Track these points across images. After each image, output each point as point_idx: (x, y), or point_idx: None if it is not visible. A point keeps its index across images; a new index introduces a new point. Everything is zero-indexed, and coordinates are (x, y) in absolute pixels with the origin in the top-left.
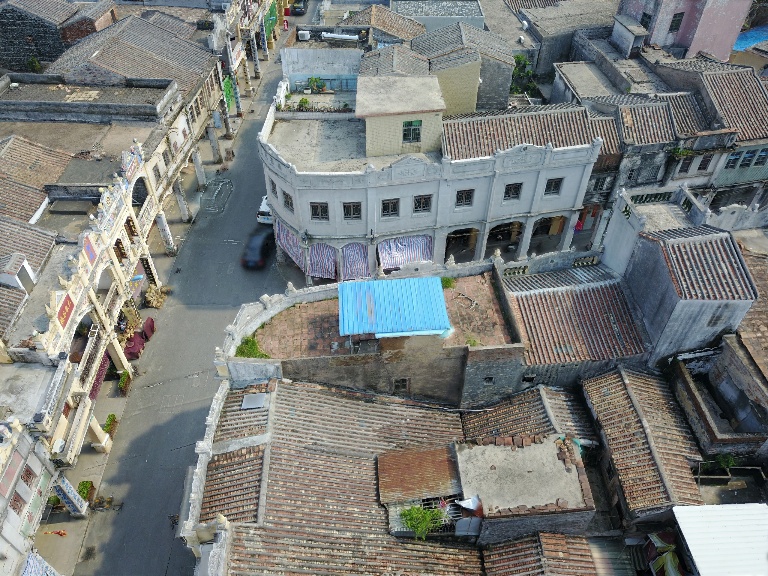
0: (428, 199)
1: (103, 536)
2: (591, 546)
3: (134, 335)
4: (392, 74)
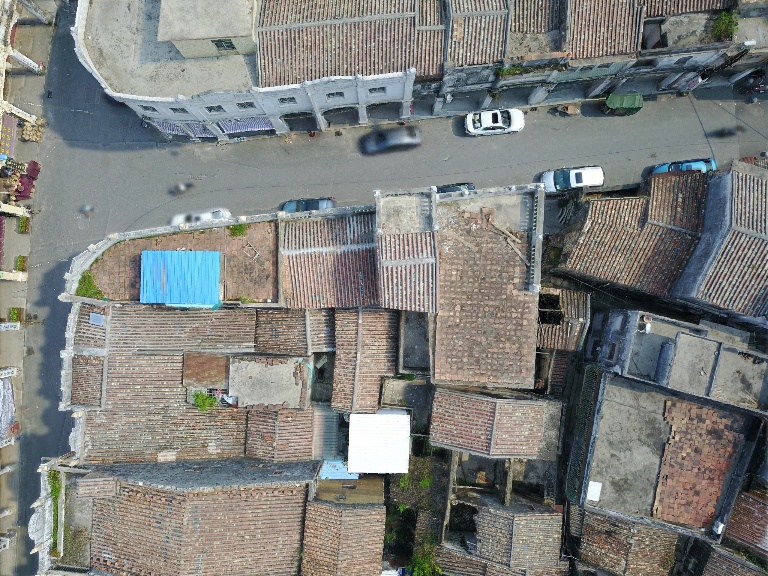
0: (250, 102)
1: (36, 341)
2: (315, 409)
3: (22, 178)
4: None
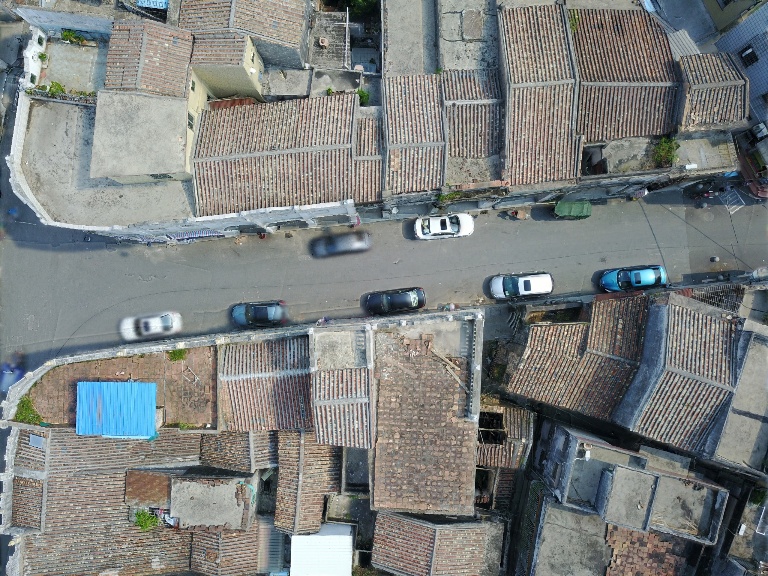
0: None
1: None
2: (261, 522)
3: None
4: (135, 94)
